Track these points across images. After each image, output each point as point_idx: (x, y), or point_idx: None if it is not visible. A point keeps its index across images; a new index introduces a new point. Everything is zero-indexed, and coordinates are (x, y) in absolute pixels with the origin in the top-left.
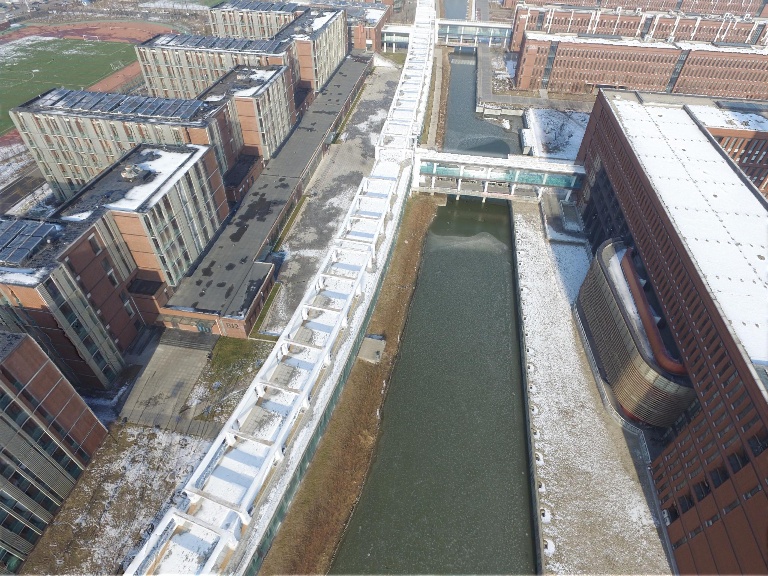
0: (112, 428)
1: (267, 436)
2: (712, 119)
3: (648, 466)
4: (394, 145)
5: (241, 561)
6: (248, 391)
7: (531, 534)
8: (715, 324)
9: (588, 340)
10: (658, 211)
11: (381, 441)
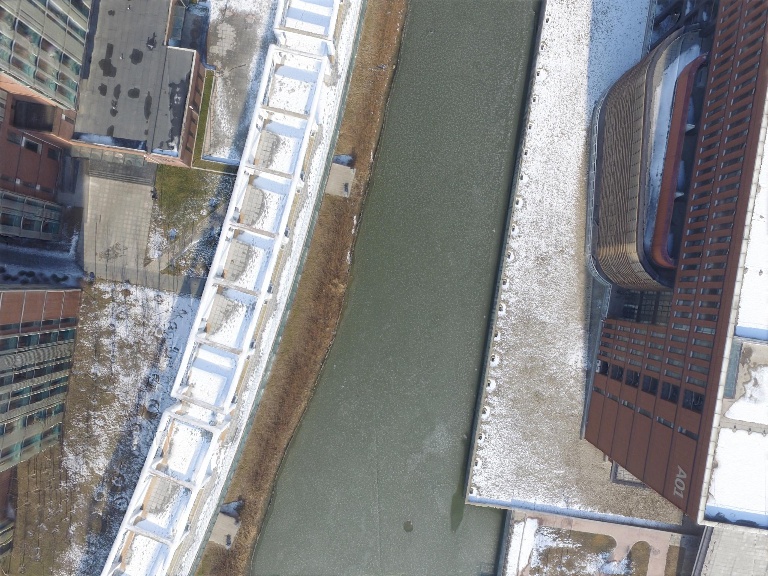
0: (83, 285)
1: (235, 328)
2: None
3: (602, 319)
4: None
5: (235, 435)
6: (204, 295)
7: (480, 369)
8: (727, 267)
9: (596, 168)
10: (767, 28)
11: (352, 287)
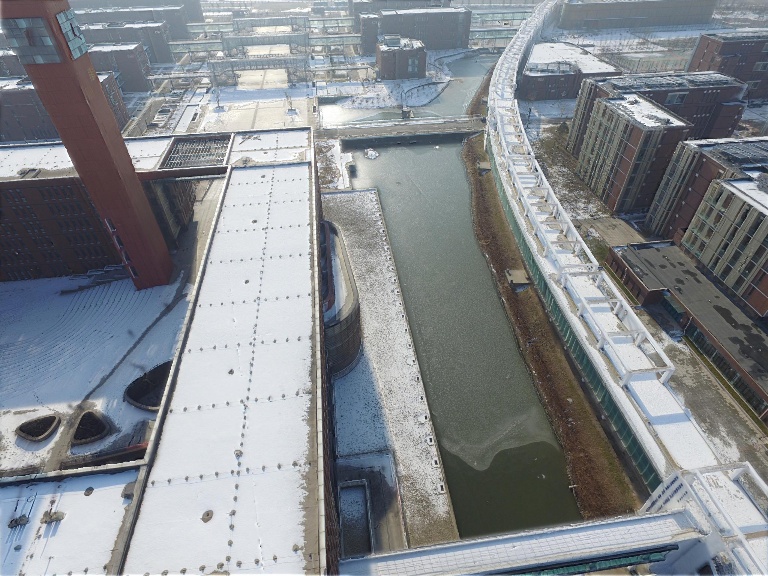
0: None
1: None
2: (85, 530)
3: None
4: (760, 549)
5: (500, 165)
6: None
7: None
8: None
9: None
10: None
11: (477, 246)
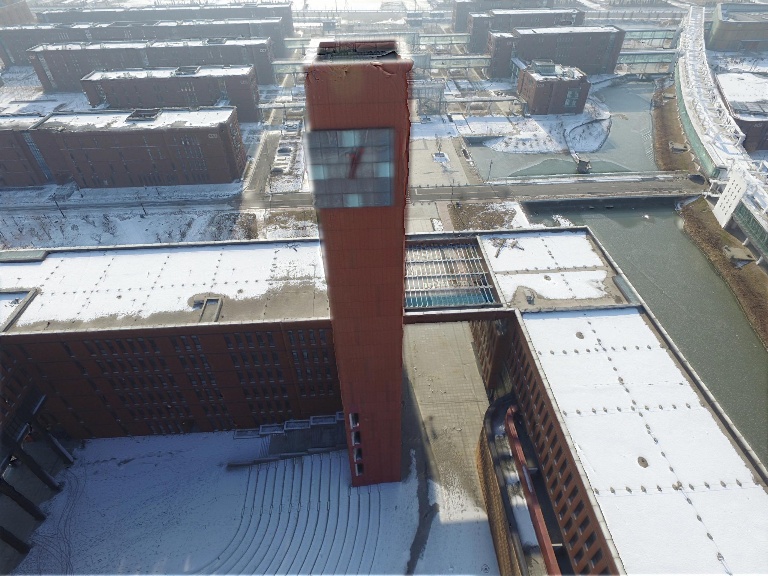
0: None
1: None
2: None
3: None
4: None
5: None
6: None
7: None
8: None
9: None
10: None
11: None
